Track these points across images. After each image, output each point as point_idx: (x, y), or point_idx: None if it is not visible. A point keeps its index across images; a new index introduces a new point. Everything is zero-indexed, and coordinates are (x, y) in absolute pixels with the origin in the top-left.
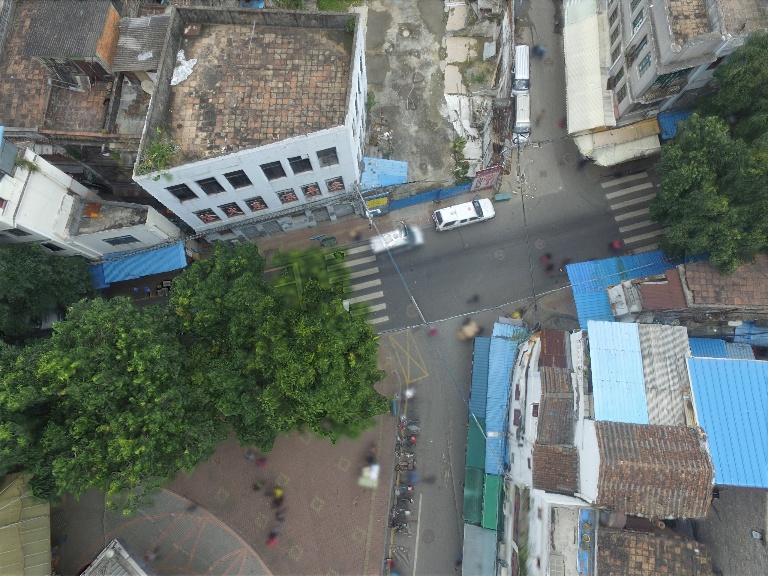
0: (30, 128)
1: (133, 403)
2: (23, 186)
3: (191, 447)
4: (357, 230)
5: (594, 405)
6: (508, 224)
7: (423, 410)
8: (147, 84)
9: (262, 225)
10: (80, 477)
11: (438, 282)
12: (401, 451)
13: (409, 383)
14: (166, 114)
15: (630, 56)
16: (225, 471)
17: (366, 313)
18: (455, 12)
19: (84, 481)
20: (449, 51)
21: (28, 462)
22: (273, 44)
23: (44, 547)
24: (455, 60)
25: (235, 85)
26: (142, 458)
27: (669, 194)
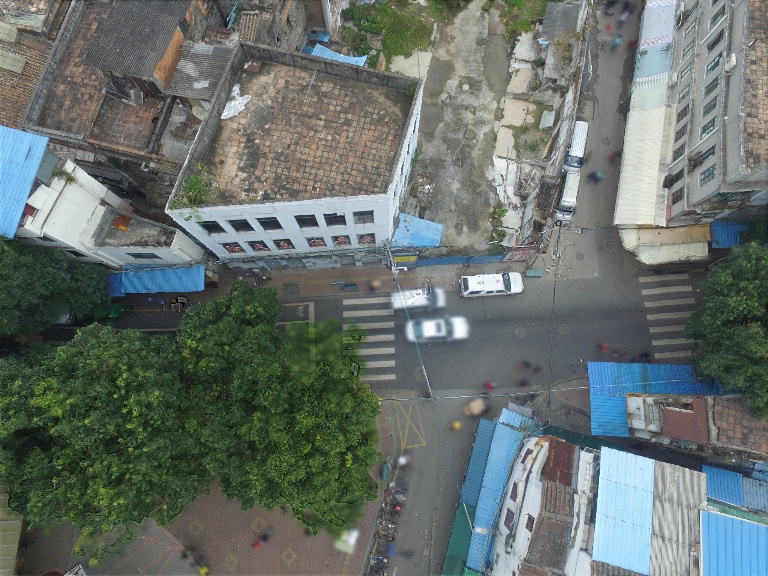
0: (76, 135)
1: (121, 444)
2: (57, 196)
3: (171, 498)
4: (380, 280)
5: (594, 542)
6: (535, 302)
7: (413, 480)
8: (198, 110)
9: (286, 261)
10: (55, 512)
11: (452, 349)
12: (383, 518)
13: (404, 448)
14: (210, 147)
15: (693, 161)
16: (203, 503)
17: (374, 367)
18: (519, 74)
19: (58, 516)
20: (506, 112)
21: (8, 477)
22: (330, 94)
23: (10, 552)
24: (510, 123)
25: (284, 130)
26: (119, 508)
27: (711, 319)
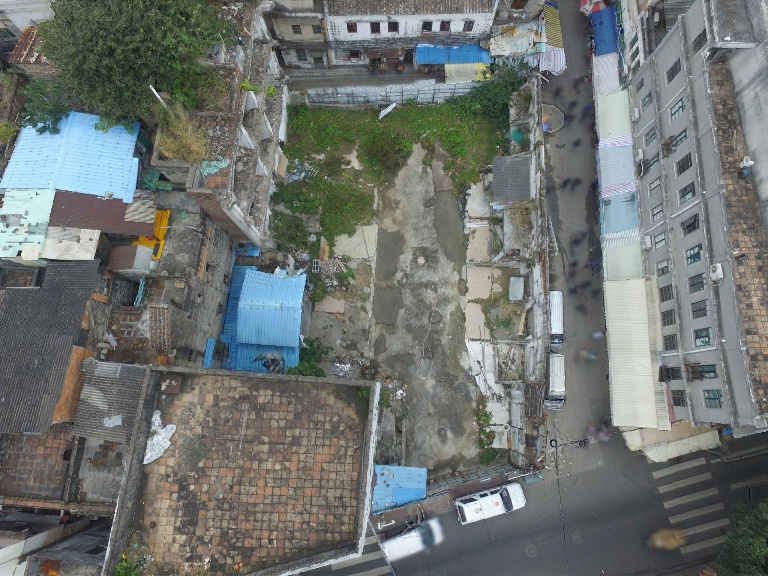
0: None
1: None
2: None
3: None
4: None
5: None
6: (540, 510)
7: None
8: None
9: None
10: None
11: None
12: None
13: None
14: (137, 506)
15: (691, 367)
16: None
17: None
18: (476, 235)
19: None
20: (470, 284)
21: None
22: (269, 405)
23: None
24: (477, 296)
25: (222, 466)
26: None
27: None
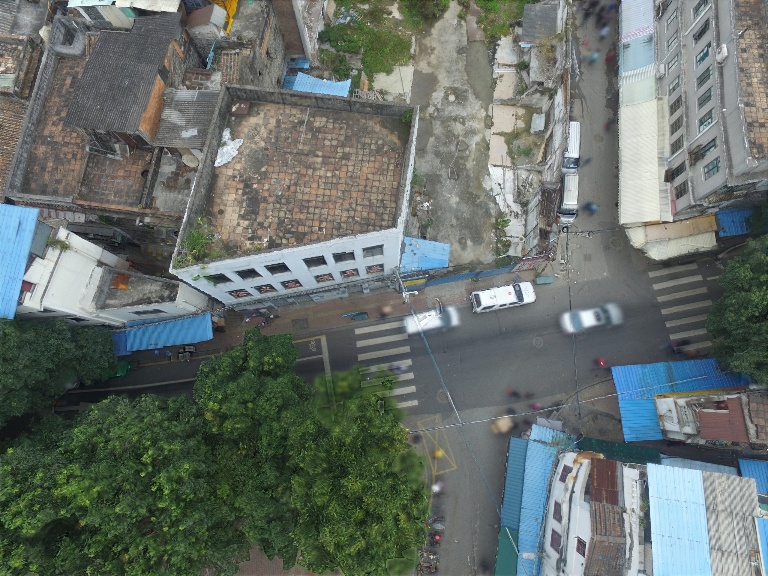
0: (64, 198)
1: (154, 523)
2: (53, 266)
3: (212, 572)
4: (390, 305)
5: (653, 565)
6: (548, 309)
7: (449, 506)
8: (188, 158)
9: None
10: None
11: (472, 367)
12: (423, 549)
13: (436, 475)
14: (207, 198)
15: (694, 154)
16: None
17: (395, 395)
18: (504, 79)
19: None
20: (495, 120)
21: (37, 569)
22: (324, 129)
23: None
24: (501, 130)
25: (282, 171)
26: None
27: (735, 316)
